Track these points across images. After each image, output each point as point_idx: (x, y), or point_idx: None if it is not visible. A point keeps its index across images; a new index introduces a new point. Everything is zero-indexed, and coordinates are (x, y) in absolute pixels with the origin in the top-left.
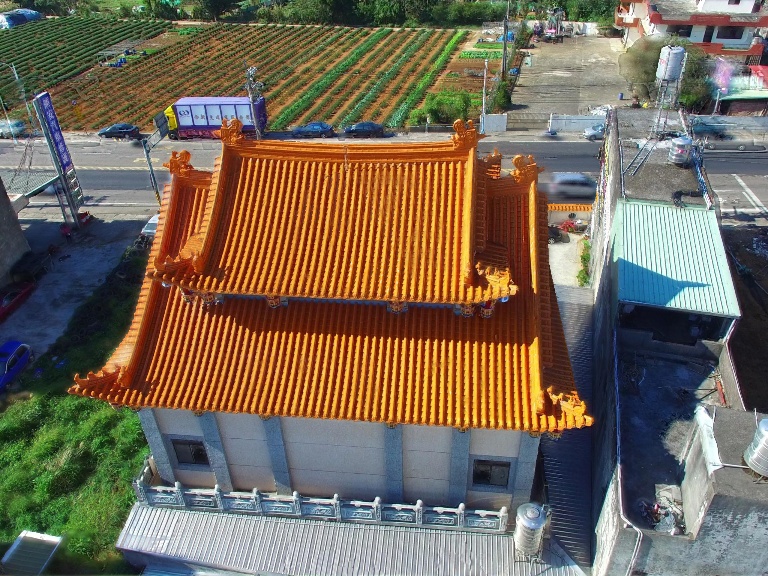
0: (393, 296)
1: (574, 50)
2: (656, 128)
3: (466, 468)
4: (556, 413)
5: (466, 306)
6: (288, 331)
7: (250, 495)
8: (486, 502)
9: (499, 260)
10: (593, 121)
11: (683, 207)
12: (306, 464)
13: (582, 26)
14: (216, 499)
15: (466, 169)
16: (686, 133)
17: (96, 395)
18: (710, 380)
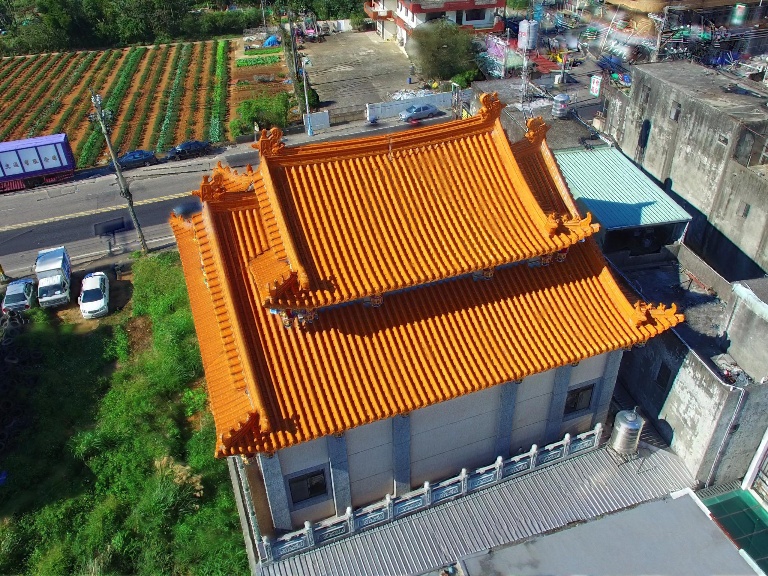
0: (499, 261)
1: (341, 46)
2: (524, 92)
3: (564, 401)
4: (650, 321)
5: (549, 255)
6: (397, 325)
7: (383, 504)
8: (573, 428)
9: (549, 211)
10: (404, 105)
11: (592, 149)
12: (425, 453)
13: (336, 24)
14: (348, 523)
15: (495, 138)
16: (543, 93)
17: (245, 450)
18: (683, 274)
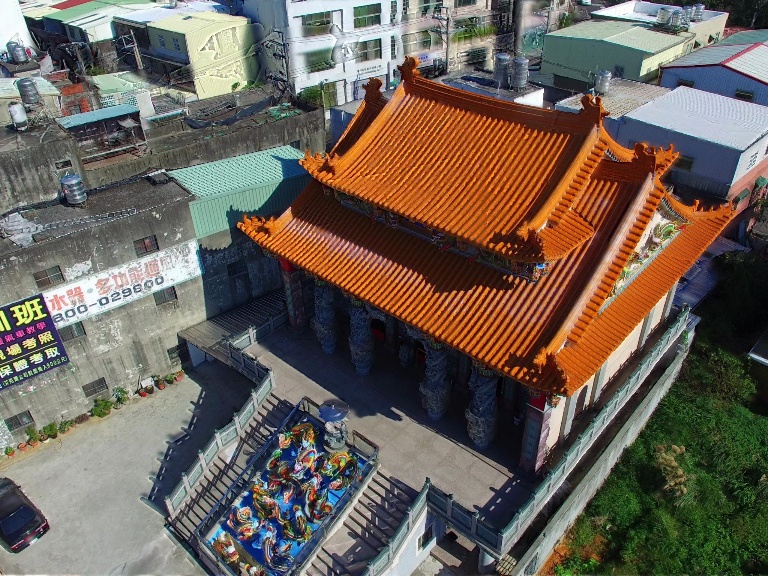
0: None
1: None
2: None
3: None
4: None
5: None
6: None
7: None
8: None
9: None
10: None
11: None
12: None
13: None
14: None
15: None
16: None
17: None
18: None
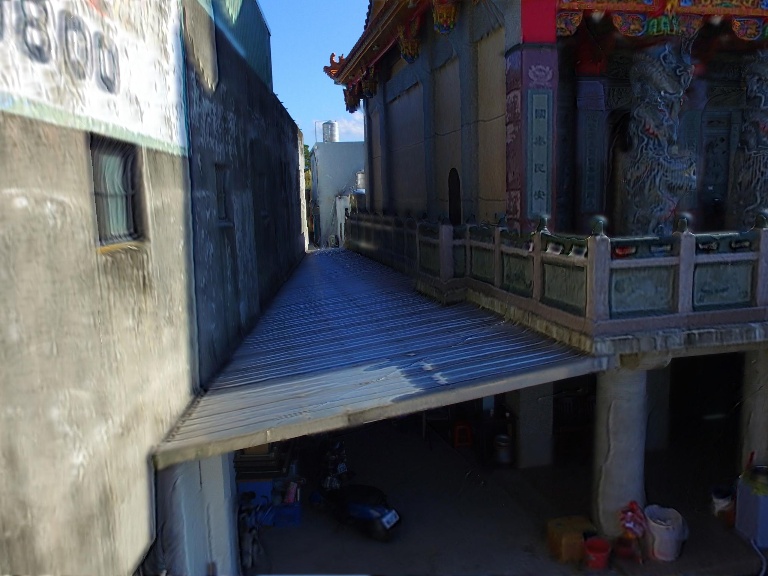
0: None
1: None
2: None
3: None
4: None
5: None
6: None
7: None
8: None
9: None
10: None
11: None
12: None
13: None
14: None
15: None
16: None
17: None
18: None
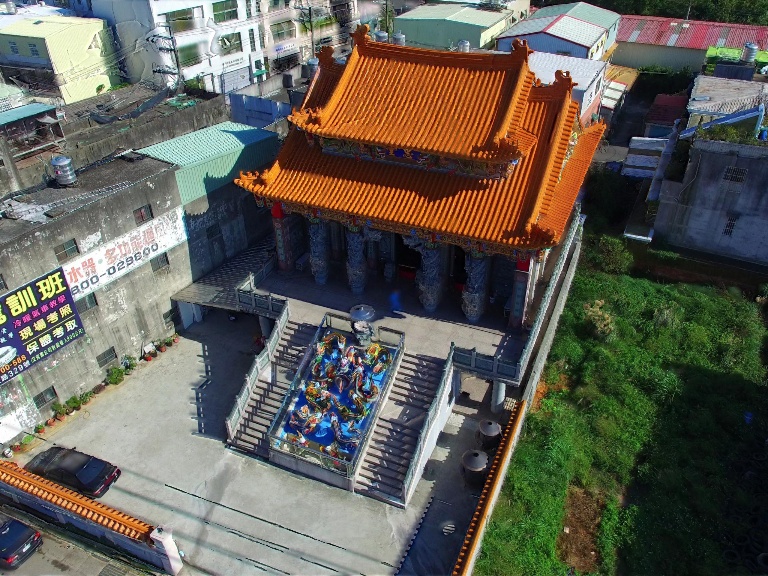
0: None
1: None
2: (4, 208)
3: None
4: None
5: None
6: None
7: None
8: None
9: None
10: None
11: None
12: None
13: None
14: None
15: None
16: None
17: None
18: None
